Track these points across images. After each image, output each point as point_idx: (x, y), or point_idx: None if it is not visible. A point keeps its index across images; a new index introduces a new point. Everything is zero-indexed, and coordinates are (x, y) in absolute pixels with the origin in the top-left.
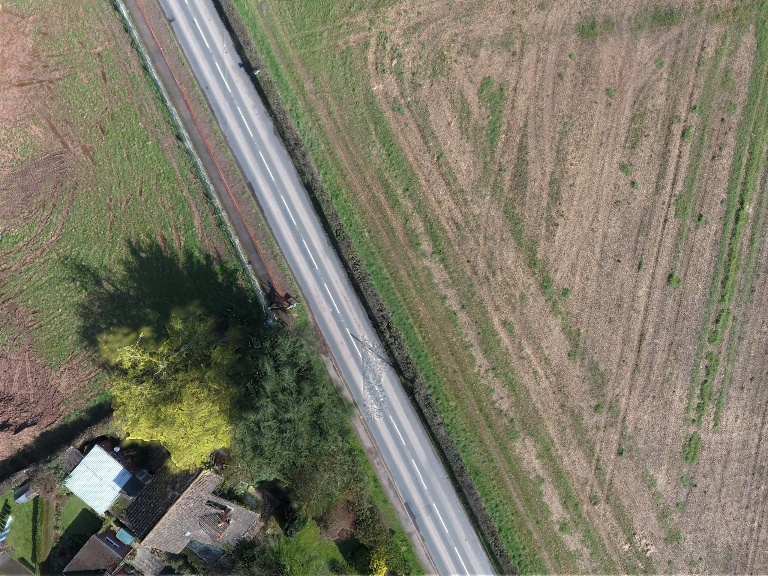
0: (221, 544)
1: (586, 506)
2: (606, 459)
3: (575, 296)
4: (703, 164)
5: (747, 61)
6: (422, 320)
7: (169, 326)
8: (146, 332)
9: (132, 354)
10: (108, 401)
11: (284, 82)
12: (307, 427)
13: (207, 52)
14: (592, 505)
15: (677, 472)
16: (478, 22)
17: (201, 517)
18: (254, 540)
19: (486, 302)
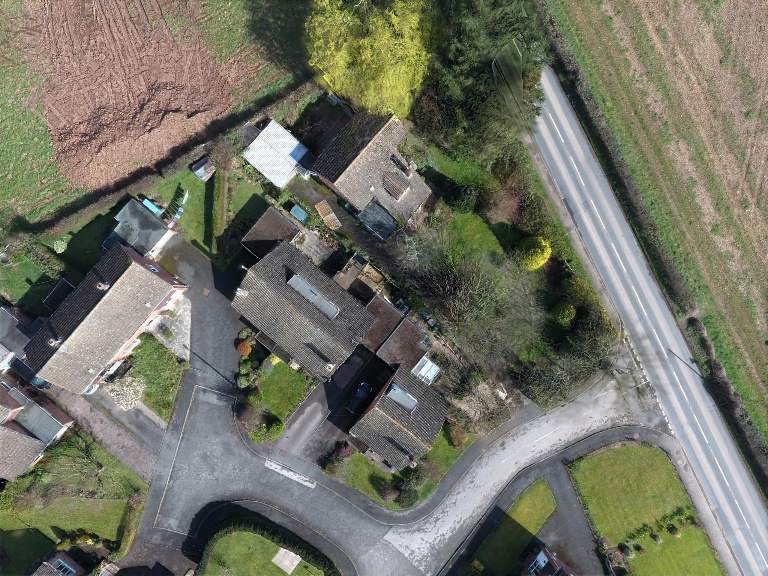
0: (397, 214)
1: (737, 209)
2: (757, 164)
3: (726, 5)
4: None
5: None
6: (579, 23)
7: None
8: None
9: None
10: (276, 93)
11: None
12: (469, 122)
13: None
14: (743, 209)
15: None
16: None
17: (385, 172)
18: (418, 230)
19: (640, 9)
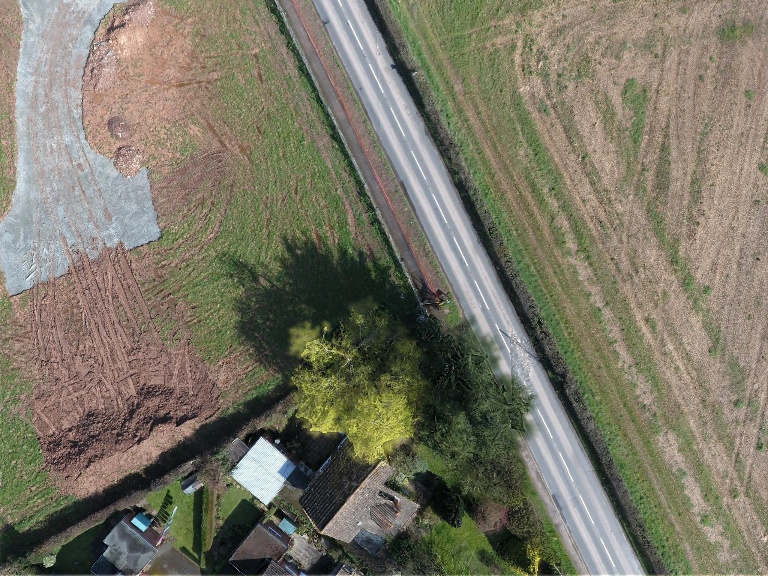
0: (385, 534)
1: (726, 499)
2: (746, 453)
3: (715, 293)
4: None
5: None
6: (568, 316)
7: (343, 321)
8: (301, 327)
9: (321, 348)
10: (265, 394)
11: (435, 83)
12: None
13: (361, 54)
14: (732, 498)
15: None
16: (621, 25)
17: (373, 507)
18: (407, 531)
19: (629, 299)
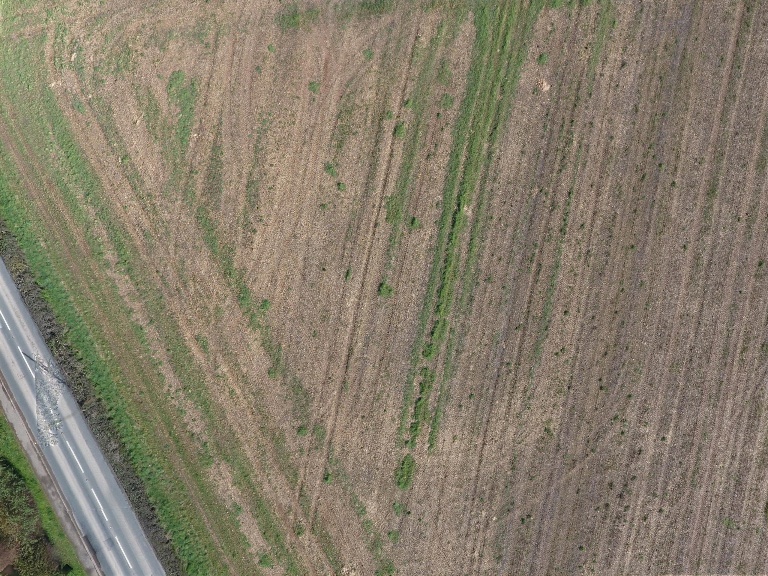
0: None
1: (289, 536)
2: (310, 485)
3: (276, 308)
4: (417, 163)
5: (466, 51)
6: (105, 336)
7: None
8: None
9: None
10: None
11: None
12: None
13: None
14: (296, 535)
15: (389, 498)
16: (167, 12)
17: None
18: None
19: (177, 316)
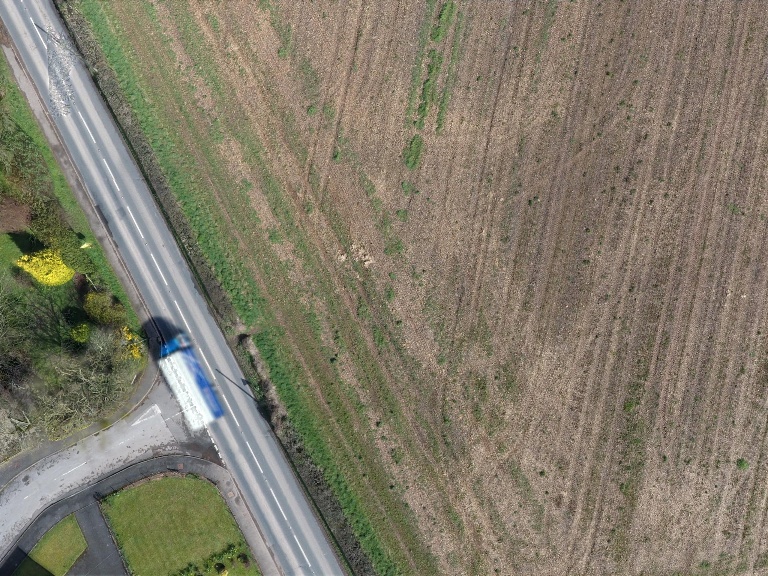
0: None
1: (299, 214)
2: (320, 163)
3: None
4: None
5: None
6: (116, 12)
7: None
8: None
9: None
10: None
11: None
12: None
13: None
14: (305, 213)
15: (397, 177)
16: None
17: None
18: None
19: None
